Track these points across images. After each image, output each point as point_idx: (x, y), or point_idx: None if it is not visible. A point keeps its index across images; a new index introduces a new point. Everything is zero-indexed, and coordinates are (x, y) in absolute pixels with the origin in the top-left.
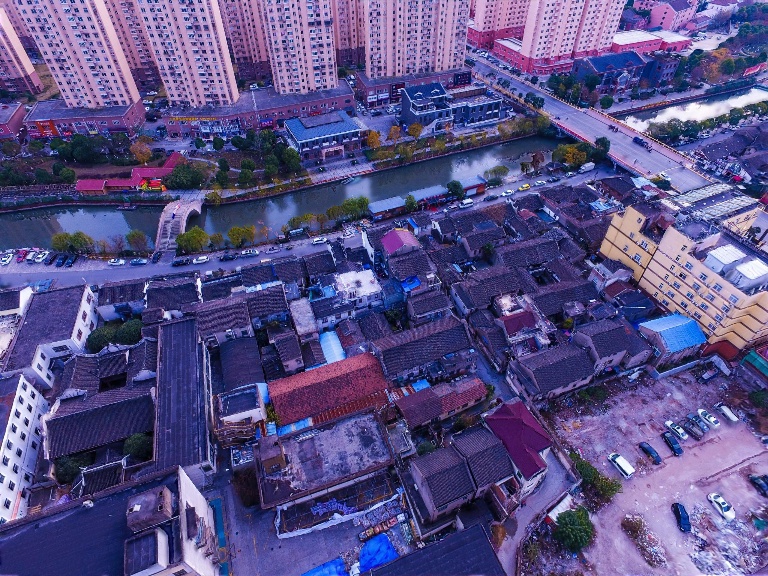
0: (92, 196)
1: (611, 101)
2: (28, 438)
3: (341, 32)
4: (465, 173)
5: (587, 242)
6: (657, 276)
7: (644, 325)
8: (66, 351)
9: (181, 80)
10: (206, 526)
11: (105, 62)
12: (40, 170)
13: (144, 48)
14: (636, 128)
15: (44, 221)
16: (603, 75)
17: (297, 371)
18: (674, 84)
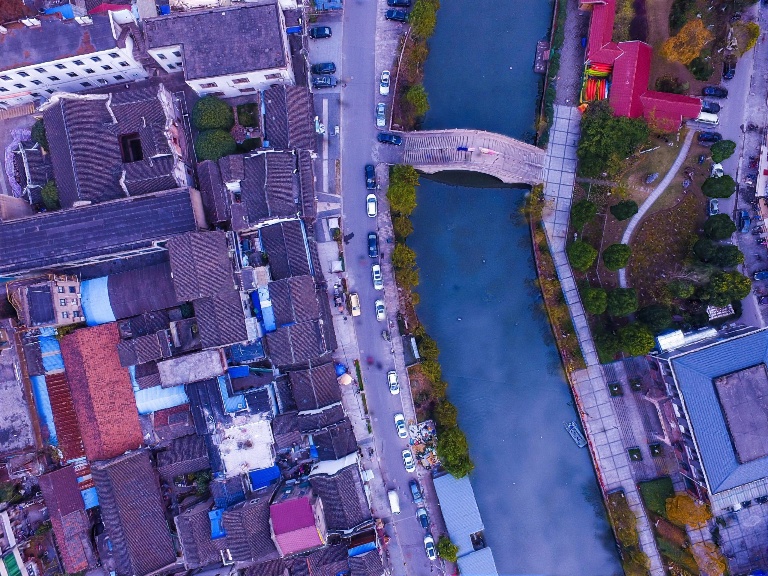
0: None
1: None
2: (80, 78)
3: None
4: None
5: None
6: None
7: None
8: None
9: None
10: None
11: None
12: None
13: None
14: None
15: None
16: None
17: None
18: None
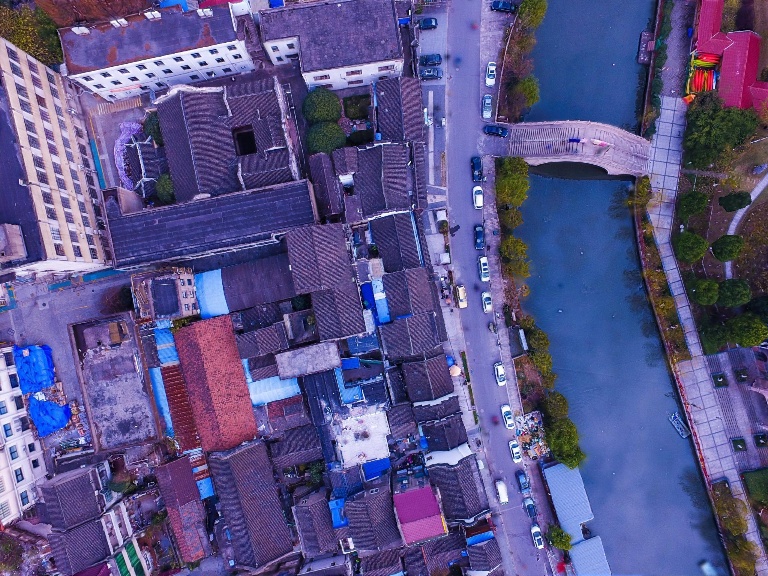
0: None
1: None
2: (192, 71)
3: None
4: None
5: None
6: None
7: None
8: None
9: None
10: (74, 270)
11: None
12: None
13: None
14: None
15: None
16: None
17: None
18: None
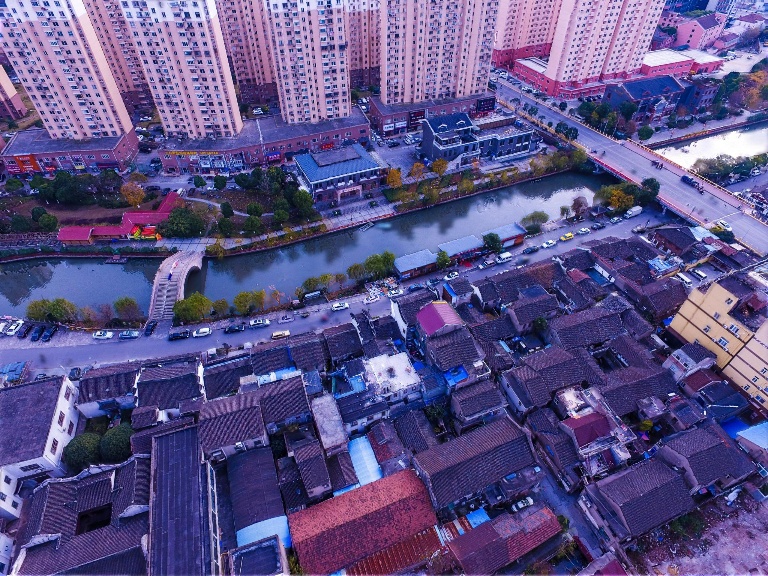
0: (76, 247)
1: (651, 132)
2: None
3: (352, 52)
4: (494, 214)
5: (652, 312)
6: (750, 367)
7: (745, 436)
8: (37, 469)
9: (178, 110)
10: None
11: (93, 90)
12: (16, 217)
13: (137, 69)
14: (682, 164)
15: (21, 275)
16: (639, 102)
17: (323, 495)
18: (712, 110)
